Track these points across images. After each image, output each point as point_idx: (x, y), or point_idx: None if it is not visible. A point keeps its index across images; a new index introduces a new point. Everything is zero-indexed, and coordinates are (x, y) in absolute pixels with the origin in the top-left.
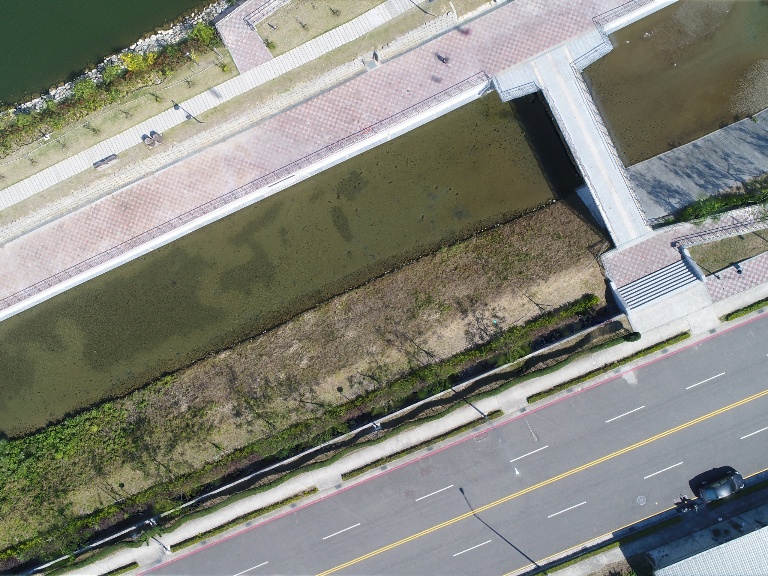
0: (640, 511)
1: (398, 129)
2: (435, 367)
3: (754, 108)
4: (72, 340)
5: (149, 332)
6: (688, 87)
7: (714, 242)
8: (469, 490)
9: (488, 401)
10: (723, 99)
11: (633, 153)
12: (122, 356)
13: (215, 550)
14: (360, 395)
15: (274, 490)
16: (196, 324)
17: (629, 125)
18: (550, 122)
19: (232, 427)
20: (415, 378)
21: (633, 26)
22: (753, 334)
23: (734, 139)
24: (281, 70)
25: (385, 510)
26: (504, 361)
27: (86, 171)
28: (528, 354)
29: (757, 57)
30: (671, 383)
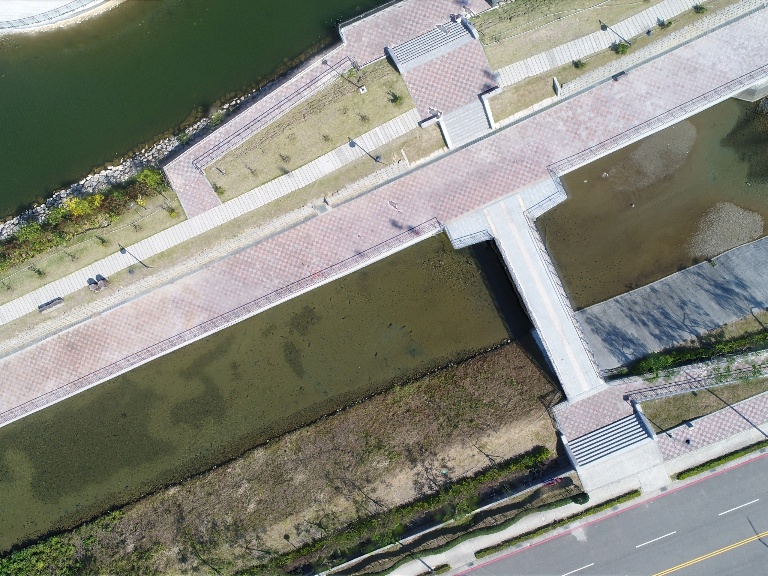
0: None
1: (350, 271)
2: (383, 517)
3: (713, 251)
4: (20, 471)
5: (98, 464)
6: (646, 228)
7: (667, 397)
8: None
9: (435, 555)
10: (681, 241)
11: (590, 294)
12: (71, 488)
13: None
14: (307, 543)
15: None
16: (146, 457)
17: (586, 266)
18: (503, 270)
19: (177, 573)
20: (362, 529)
21: (591, 165)
22: (705, 493)
23: (691, 285)
24: (229, 216)
25: None
26: (452, 514)
27: (31, 314)
28: (476, 509)
29: (717, 199)
30: (621, 541)
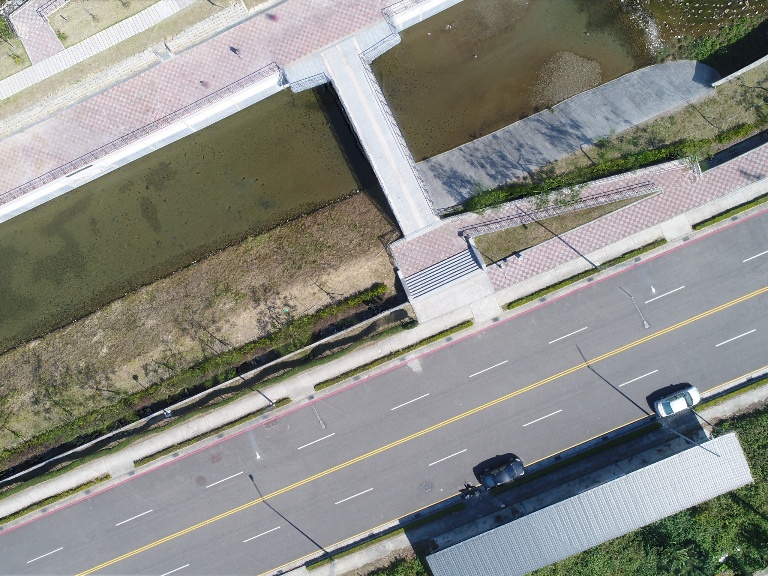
0: (425, 498)
1: (197, 120)
2: (227, 355)
3: (553, 99)
4: None
5: None
6: (489, 79)
7: (499, 231)
8: (258, 477)
9: (276, 389)
10: (523, 90)
11: (435, 144)
12: None
13: (11, 536)
14: (155, 383)
15: (68, 477)
16: (9, 313)
17: (431, 116)
18: (341, 113)
19: (30, 415)
20: (206, 366)
21: (435, 18)
22: (535, 322)
23: (530, 130)
24: (72, 61)
25: (177, 497)
26: None
27: None
28: (315, 342)
29: (556, 49)
30: (455, 371)
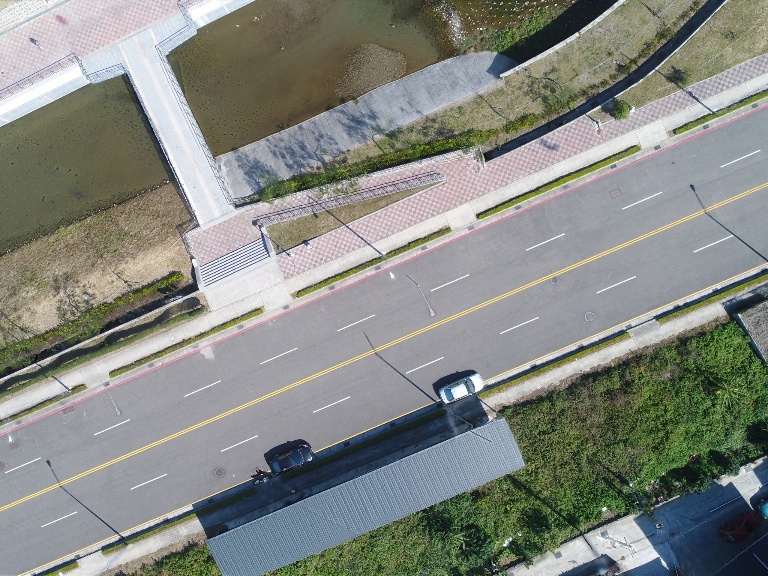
0: (218, 483)
1: (3, 110)
2: (27, 343)
3: (359, 91)
4: None
5: None
6: (296, 70)
7: (291, 220)
8: (55, 463)
9: (72, 376)
10: (329, 82)
11: (244, 135)
12: None
13: None
14: None
15: None
16: None
17: (240, 107)
18: None
19: None
20: (5, 353)
21: (243, 10)
22: (324, 310)
23: (333, 121)
24: None
25: None
26: (89, 337)
27: None
28: (109, 330)
29: (362, 41)
30: (246, 358)
